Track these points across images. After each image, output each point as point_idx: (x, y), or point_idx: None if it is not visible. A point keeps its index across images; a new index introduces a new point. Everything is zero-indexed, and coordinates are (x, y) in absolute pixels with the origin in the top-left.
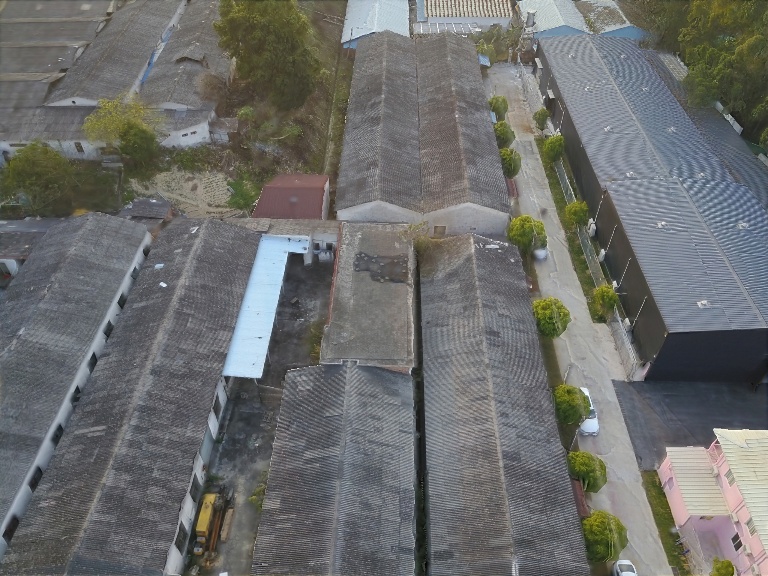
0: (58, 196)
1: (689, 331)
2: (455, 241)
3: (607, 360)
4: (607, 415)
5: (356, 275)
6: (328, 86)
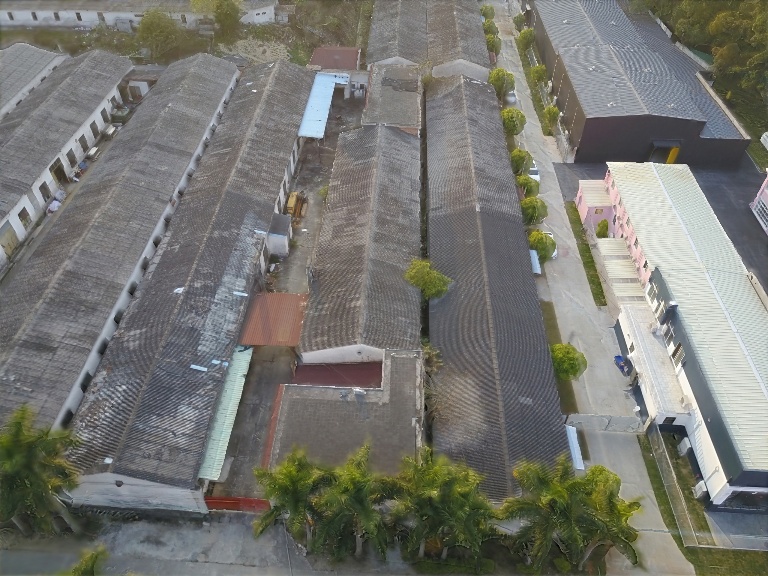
0: (174, 46)
1: (599, 117)
2: (450, 78)
3: (551, 153)
4: (547, 178)
5: (383, 88)
6: (356, 1)
